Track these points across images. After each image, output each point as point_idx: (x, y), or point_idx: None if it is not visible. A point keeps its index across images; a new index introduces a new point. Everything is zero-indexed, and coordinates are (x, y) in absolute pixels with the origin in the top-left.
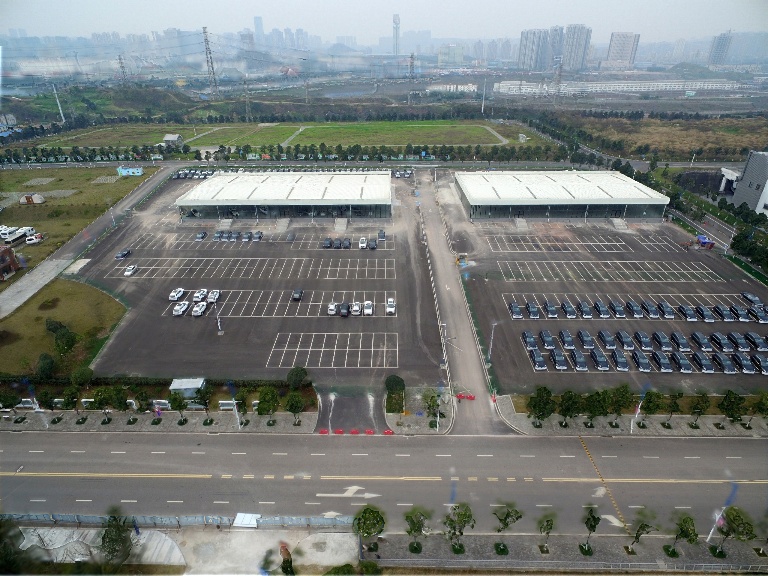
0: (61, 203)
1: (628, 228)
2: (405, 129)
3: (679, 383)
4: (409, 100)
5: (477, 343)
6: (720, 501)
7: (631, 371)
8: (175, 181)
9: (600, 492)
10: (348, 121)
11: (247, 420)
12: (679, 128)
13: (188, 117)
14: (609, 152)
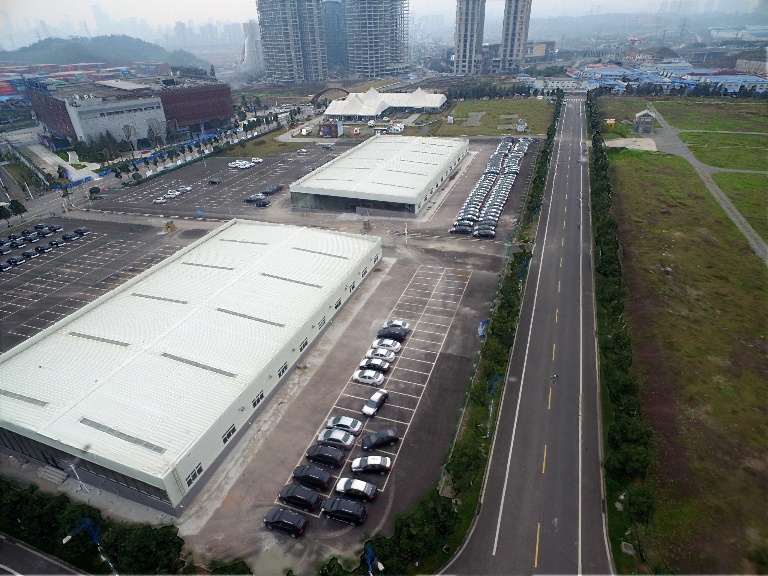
0: None
1: None
2: None
3: None
4: None
5: None
6: None
7: None
8: (494, 141)
9: None
10: None
11: None
12: None
13: None
14: None
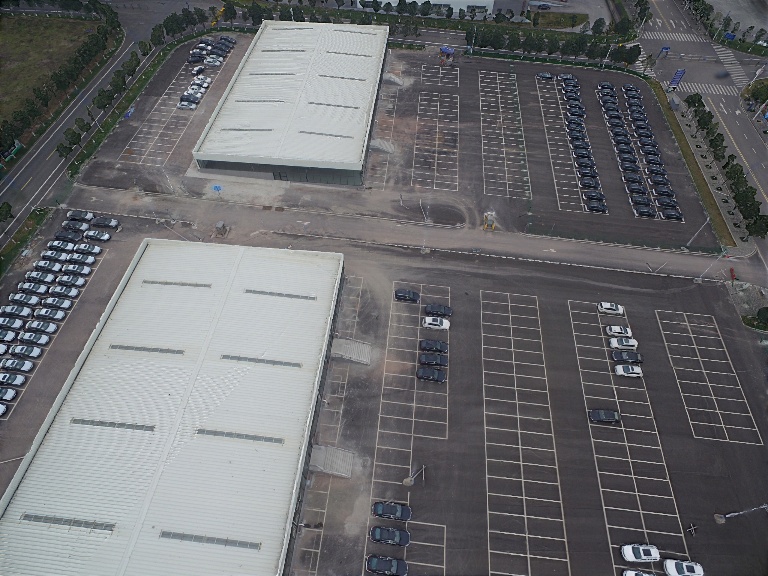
0: None
1: (402, 78)
2: None
3: (669, 154)
4: None
5: (652, 249)
6: None
7: None
8: None
9: None
10: None
11: None
12: None
13: None
14: None
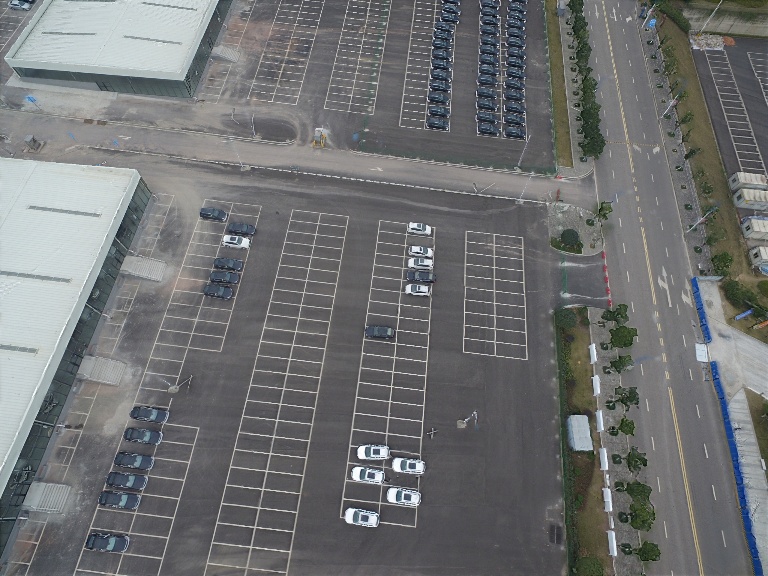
0: None
1: None
2: None
3: (536, 67)
4: None
5: (484, 169)
6: (633, 99)
7: None
8: None
9: (637, 148)
10: None
11: (604, 369)
12: None
13: None
14: None
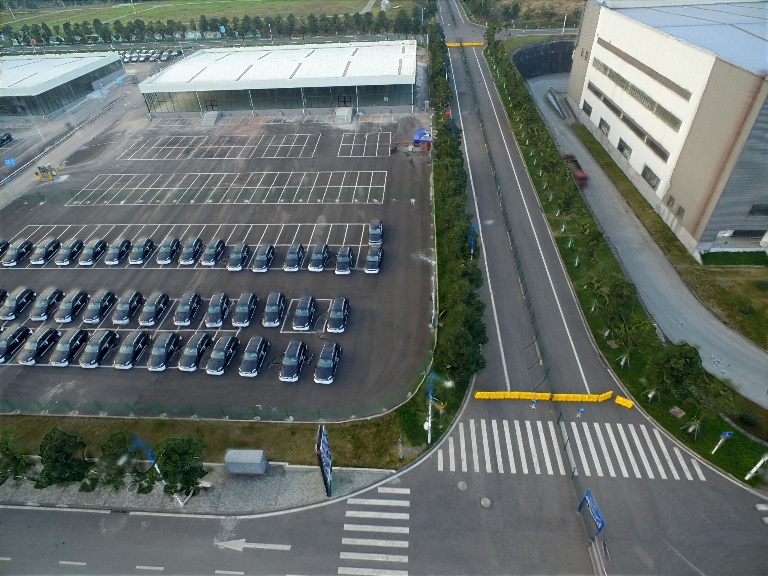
0: None
1: (352, 122)
2: (271, 2)
3: (48, 388)
4: None
5: None
6: None
7: (8, 363)
8: None
9: None
10: None
11: None
12: None
13: None
14: (480, 19)
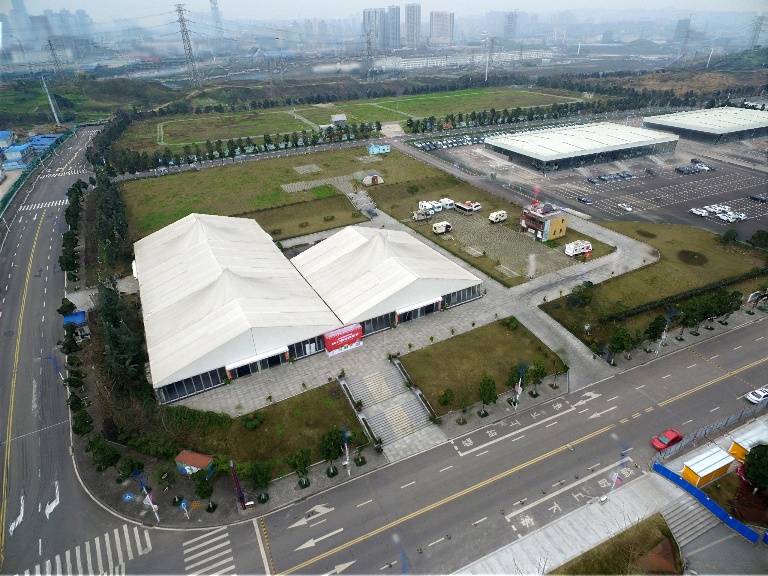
0: (401, 180)
1: None
2: (468, 98)
3: None
4: (369, 77)
5: None
6: None
7: None
8: (434, 152)
9: None
10: (389, 96)
11: None
12: (652, 81)
13: (200, 106)
14: None
